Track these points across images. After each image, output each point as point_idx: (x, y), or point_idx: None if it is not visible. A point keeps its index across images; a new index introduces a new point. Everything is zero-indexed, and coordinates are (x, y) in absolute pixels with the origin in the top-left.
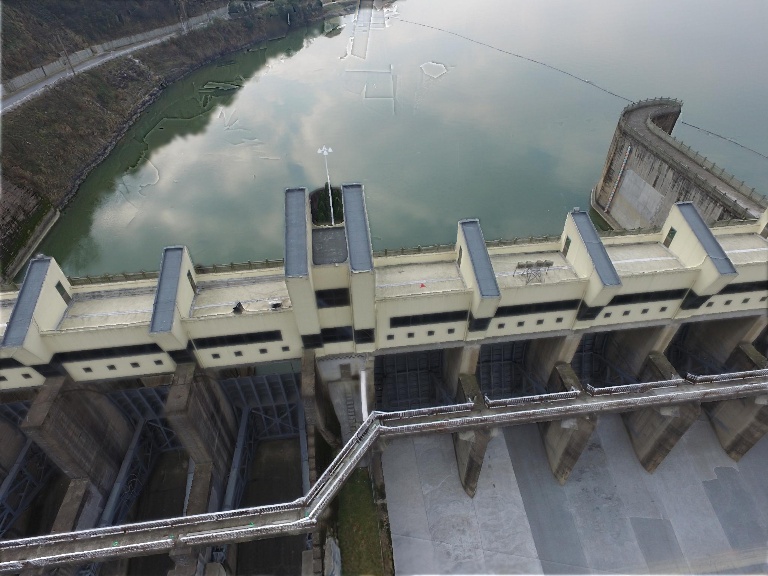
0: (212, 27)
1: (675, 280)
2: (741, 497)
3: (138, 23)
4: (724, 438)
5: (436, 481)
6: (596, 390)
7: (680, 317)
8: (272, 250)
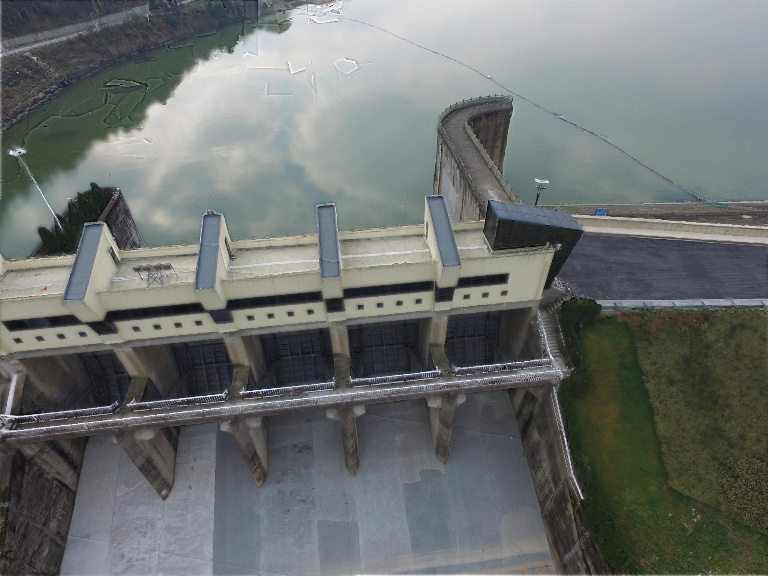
0: (129, 24)
1: (300, 283)
2: (438, 500)
3: (46, 20)
4: (433, 440)
5: (133, 483)
6: (242, 393)
7: (334, 320)
8: None
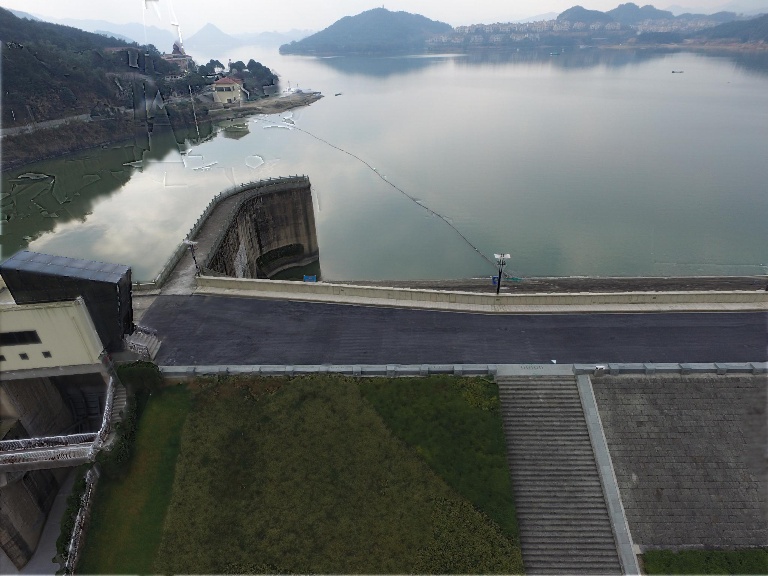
0: (65, 127)
1: None
2: None
3: None
4: None
5: None
6: None
7: None
8: None
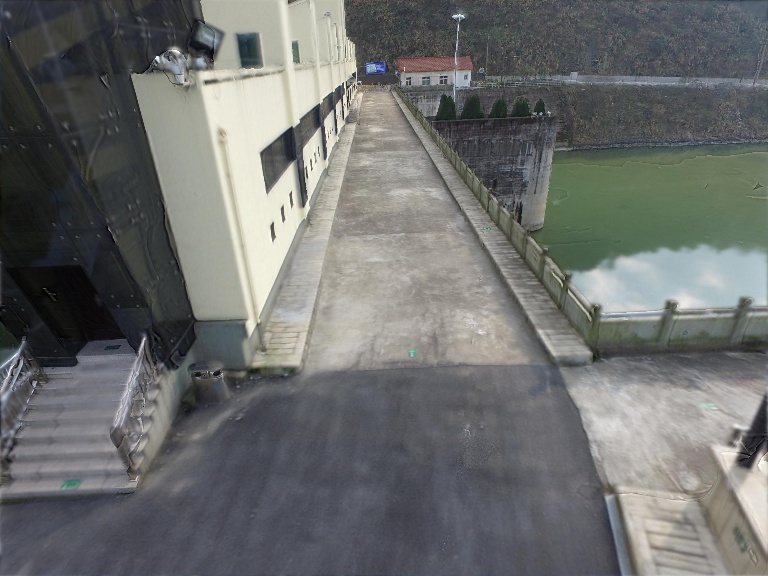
0: None
1: None
2: None
3: None
4: None
5: None
6: None
7: None
8: (564, 205)
